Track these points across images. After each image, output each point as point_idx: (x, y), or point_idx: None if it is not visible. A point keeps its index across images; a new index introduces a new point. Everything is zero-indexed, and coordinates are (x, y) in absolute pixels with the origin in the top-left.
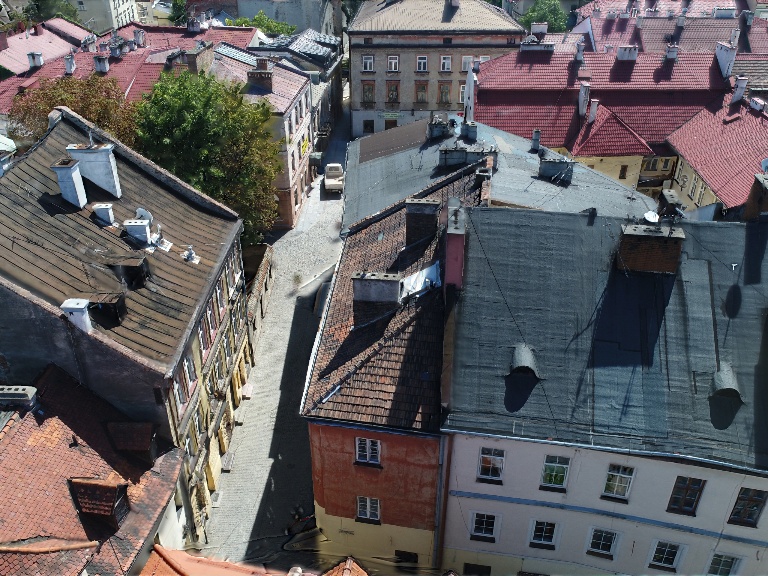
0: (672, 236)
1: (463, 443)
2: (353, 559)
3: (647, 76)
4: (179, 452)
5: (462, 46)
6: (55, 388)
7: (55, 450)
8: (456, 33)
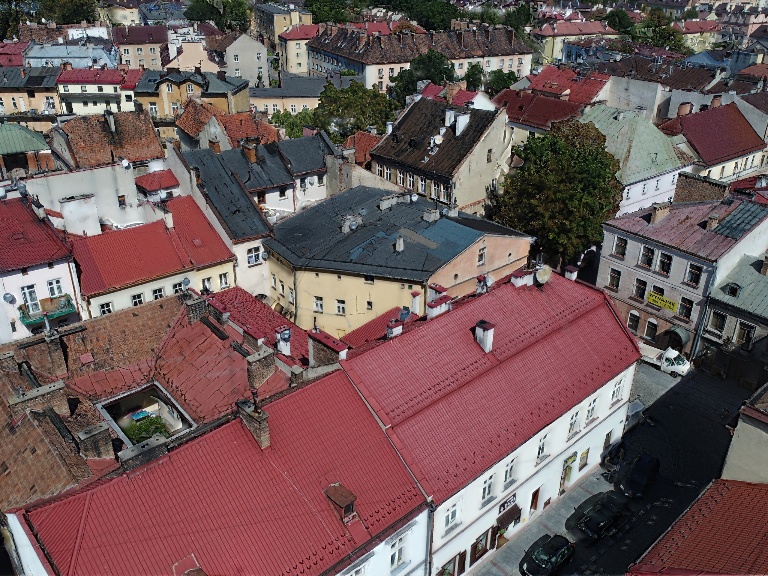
0: None
1: None
2: None
3: None
4: None
5: None
6: None
7: None
8: None
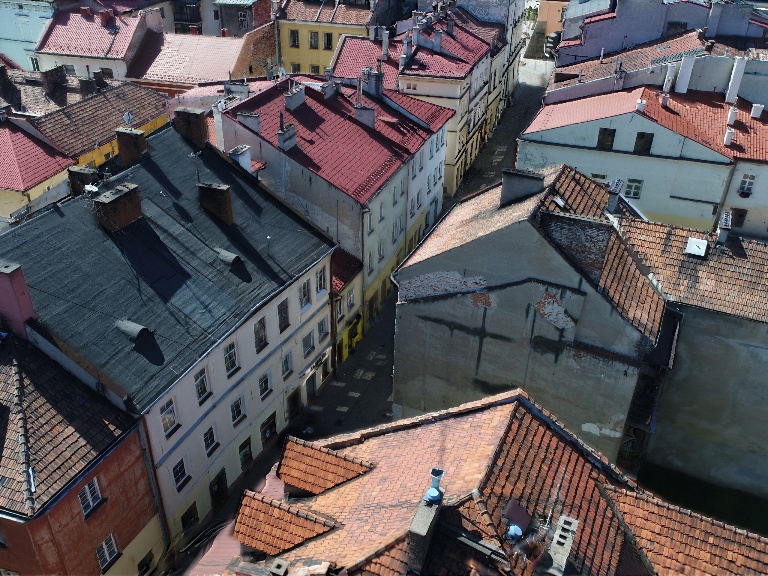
0: (132, 189)
1: (150, 416)
2: None
3: None
4: None
5: None
6: None
7: None
8: None
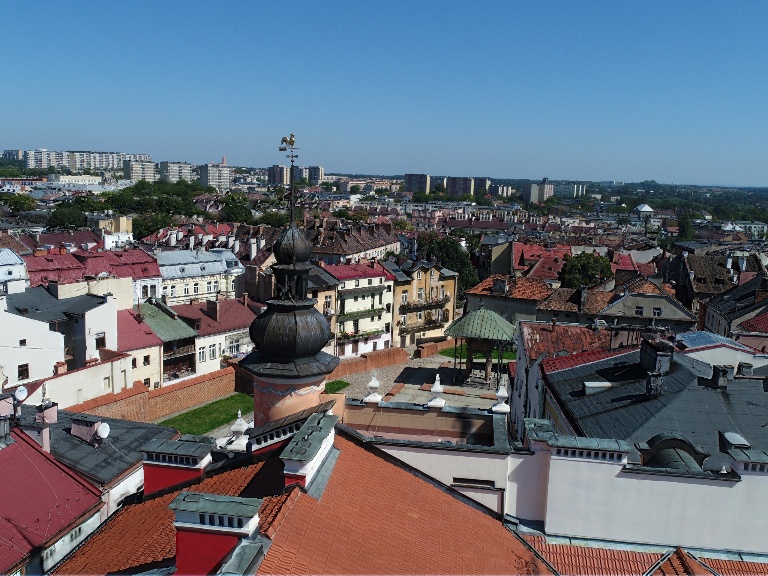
0: None
1: None
2: None
3: None
4: None
5: None
6: (681, 287)
7: None
8: None
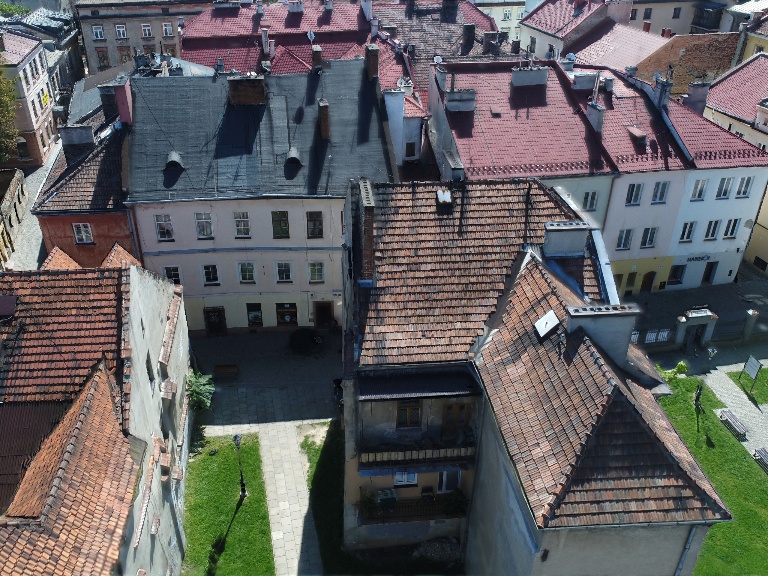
0: (256, 79)
1: (142, 214)
2: (58, 247)
3: (312, 23)
4: None
5: (178, 14)
6: None
7: None
8: (171, 3)
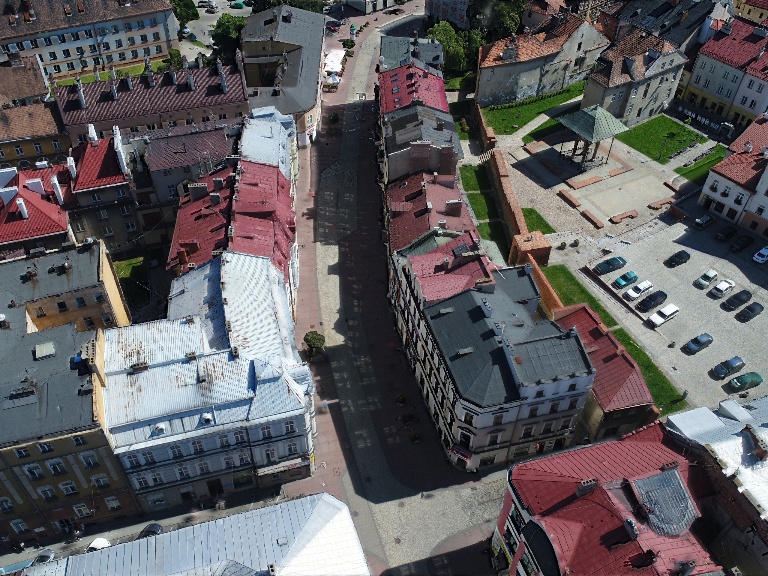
0: None
1: (621, 22)
2: None
3: None
4: (578, 15)
5: None
6: None
7: (561, 0)
8: None
